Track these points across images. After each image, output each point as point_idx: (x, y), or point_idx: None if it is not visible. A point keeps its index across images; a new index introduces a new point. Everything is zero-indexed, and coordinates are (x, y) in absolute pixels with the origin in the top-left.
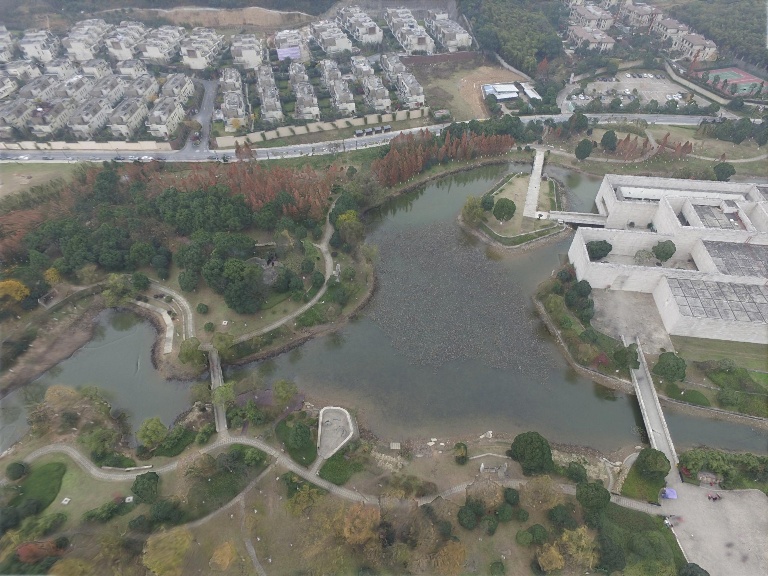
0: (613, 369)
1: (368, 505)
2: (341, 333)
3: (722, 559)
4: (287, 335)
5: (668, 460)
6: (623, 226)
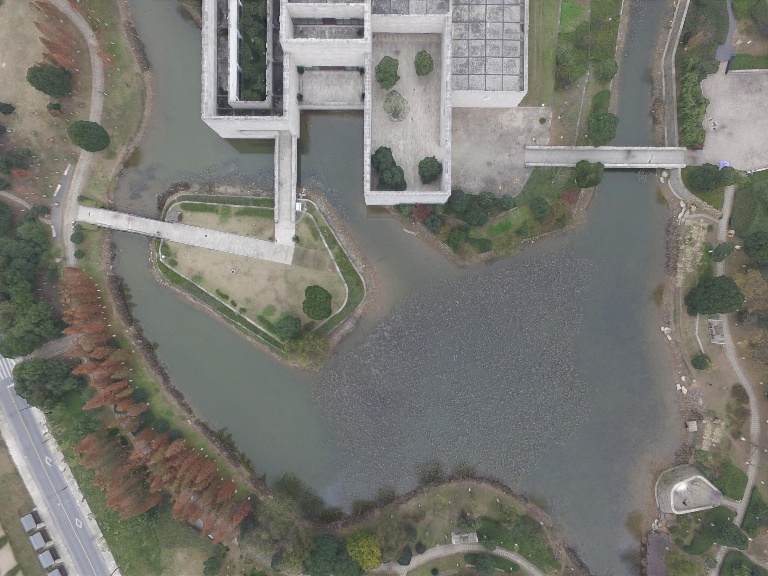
0: (575, 186)
1: (760, 447)
2: (551, 508)
3: (766, 137)
4: (570, 575)
5: (725, 168)
6: (298, 110)
